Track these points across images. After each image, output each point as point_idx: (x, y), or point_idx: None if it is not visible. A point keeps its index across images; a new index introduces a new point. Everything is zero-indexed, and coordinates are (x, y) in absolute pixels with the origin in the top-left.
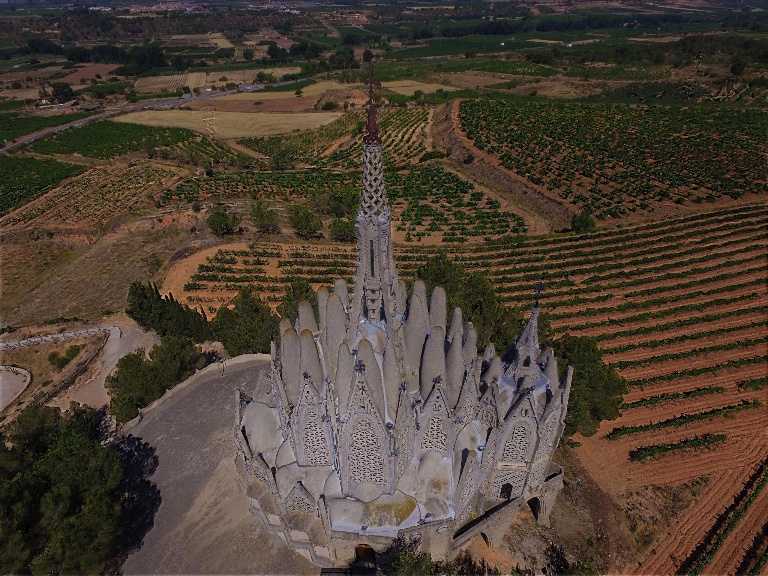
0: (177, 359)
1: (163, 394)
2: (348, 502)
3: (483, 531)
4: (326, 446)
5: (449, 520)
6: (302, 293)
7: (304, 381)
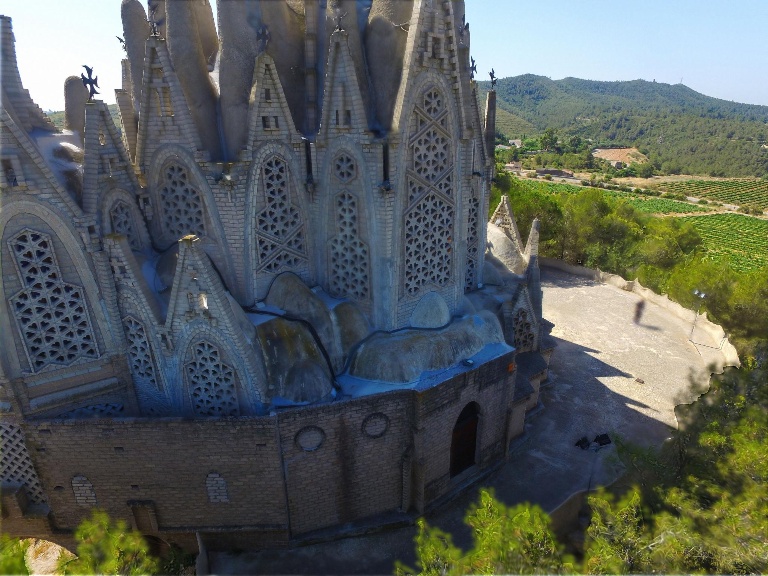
0: (716, 280)
1: (662, 295)
2: None
3: None
4: None
5: None
6: None
7: None
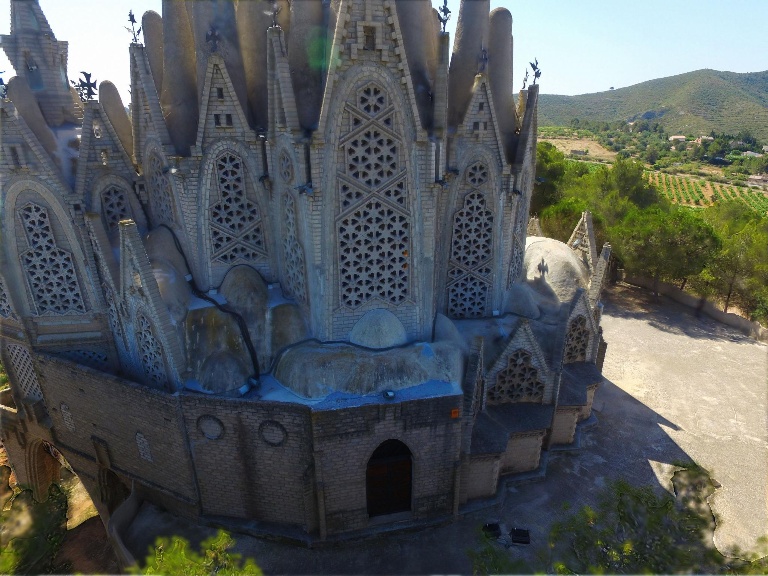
0: None
1: None
2: None
3: None
4: None
5: None
6: None
7: None
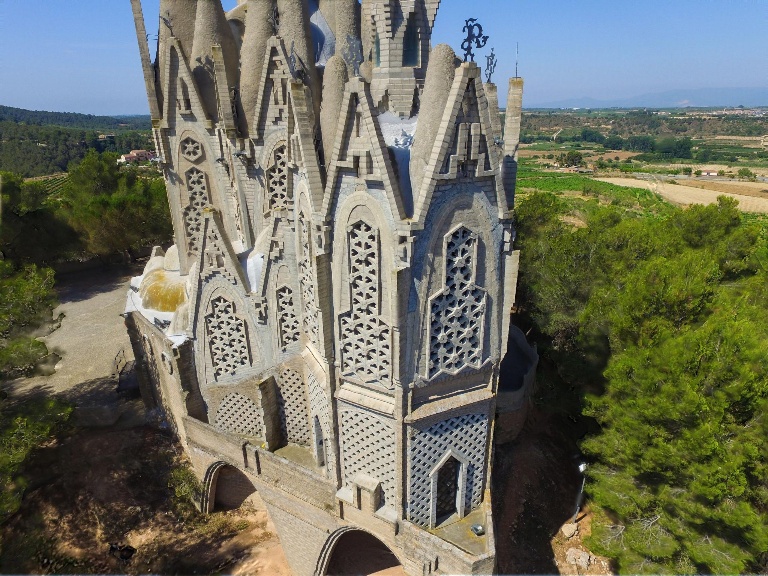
0: None
1: None
2: (161, 260)
3: (248, 476)
4: None
5: (168, 343)
6: None
7: None
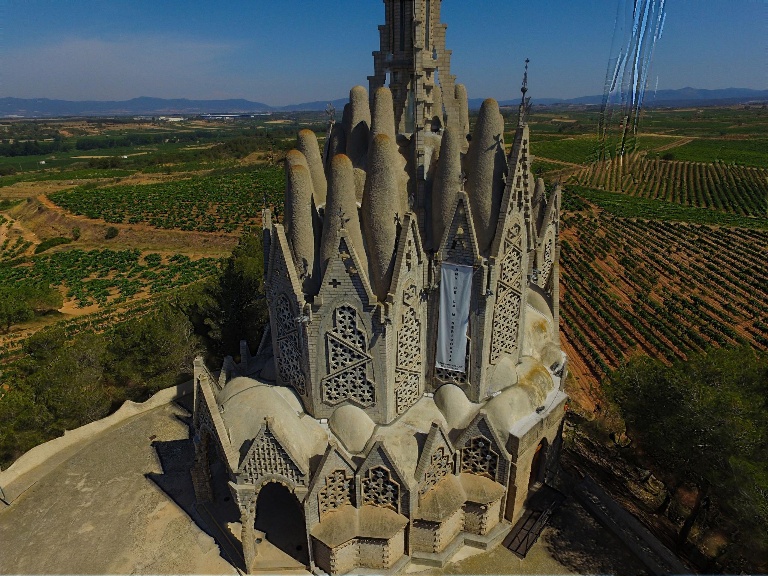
0: None
1: None
2: (503, 395)
3: None
4: (420, 357)
5: None
6: (57, 348)
7: (411, 214)
